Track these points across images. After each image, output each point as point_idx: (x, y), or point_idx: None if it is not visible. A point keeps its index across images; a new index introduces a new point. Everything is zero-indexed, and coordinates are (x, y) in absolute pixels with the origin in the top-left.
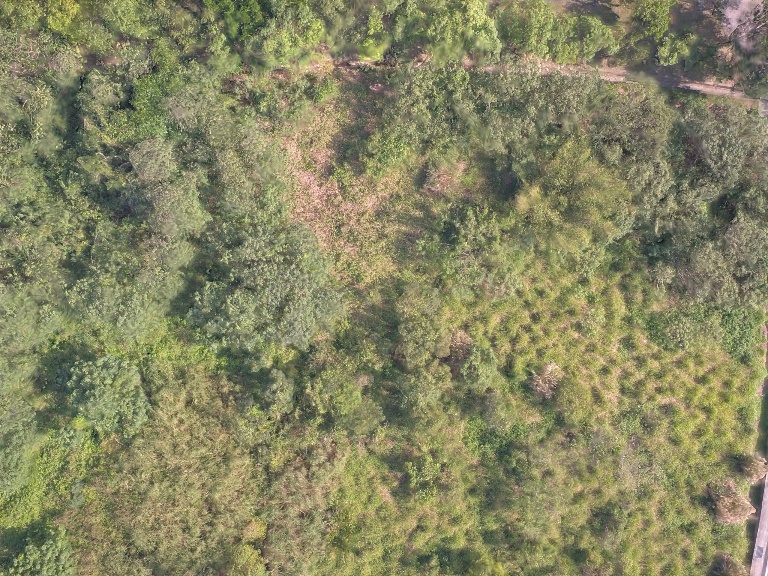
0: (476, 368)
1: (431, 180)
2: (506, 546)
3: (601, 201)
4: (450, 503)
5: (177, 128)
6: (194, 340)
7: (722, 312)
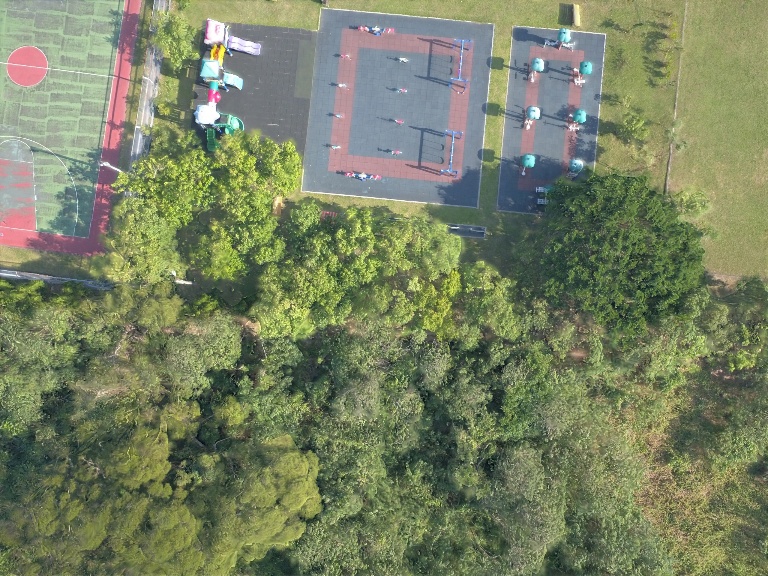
0: None
1: None
2: None
3: None
4: None
5: (544, 434)
6: None
7: None
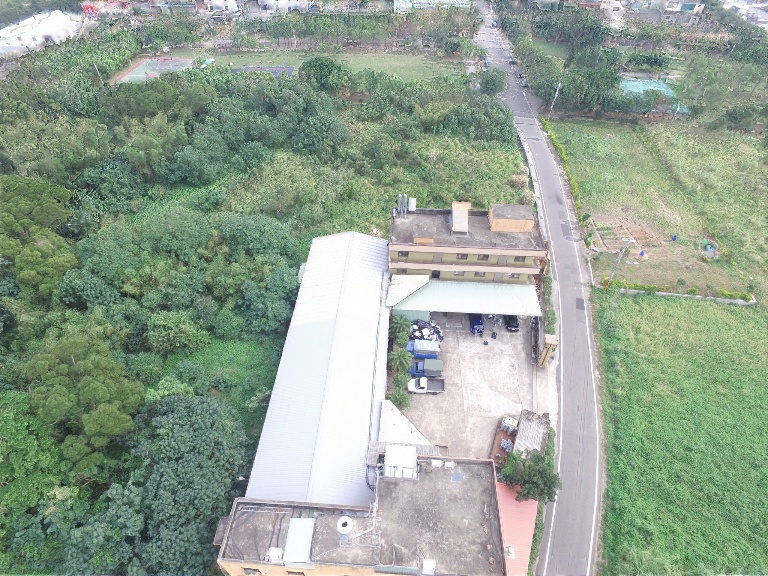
0: None
1: (385, 119)
2: None
3: (443, 108)
4: None
5: None
6: (292, 152)
7: None
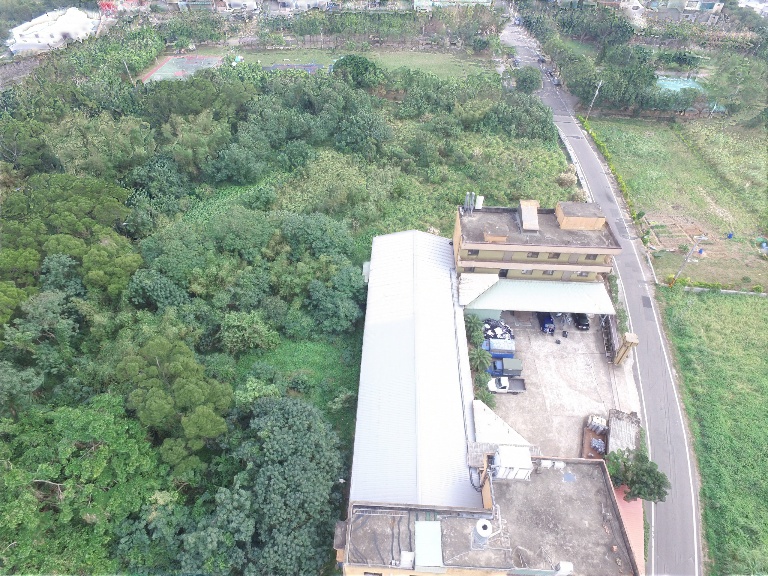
0: None
1: (423, 118)
2: None
3: (483, 106)
4: None
5: None
6: None
7: None
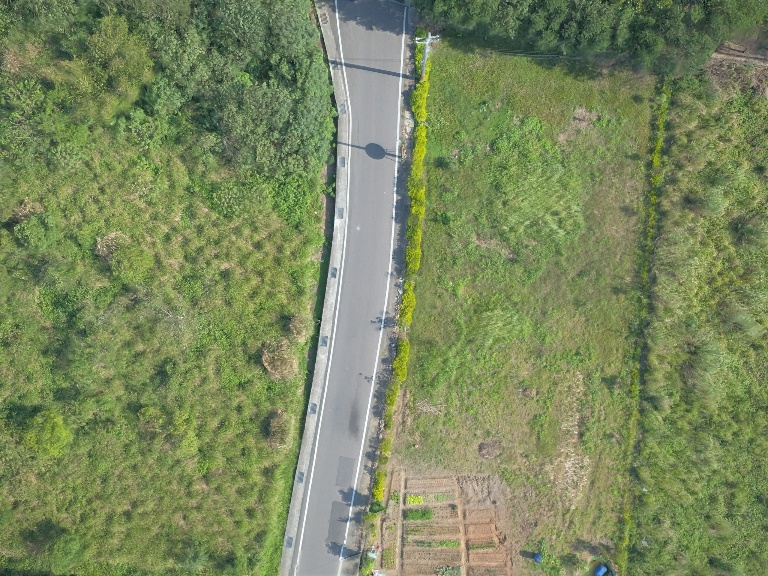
0: (24, 230)
1: (5, 62)
2: (73, 402)
3: (130, 69)
4: (22, 362)
5: None
6: None
7: (278, 181)
